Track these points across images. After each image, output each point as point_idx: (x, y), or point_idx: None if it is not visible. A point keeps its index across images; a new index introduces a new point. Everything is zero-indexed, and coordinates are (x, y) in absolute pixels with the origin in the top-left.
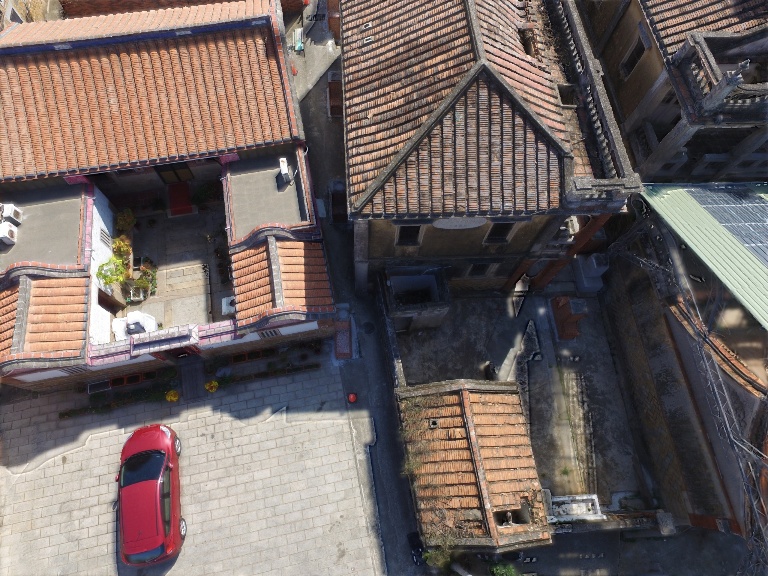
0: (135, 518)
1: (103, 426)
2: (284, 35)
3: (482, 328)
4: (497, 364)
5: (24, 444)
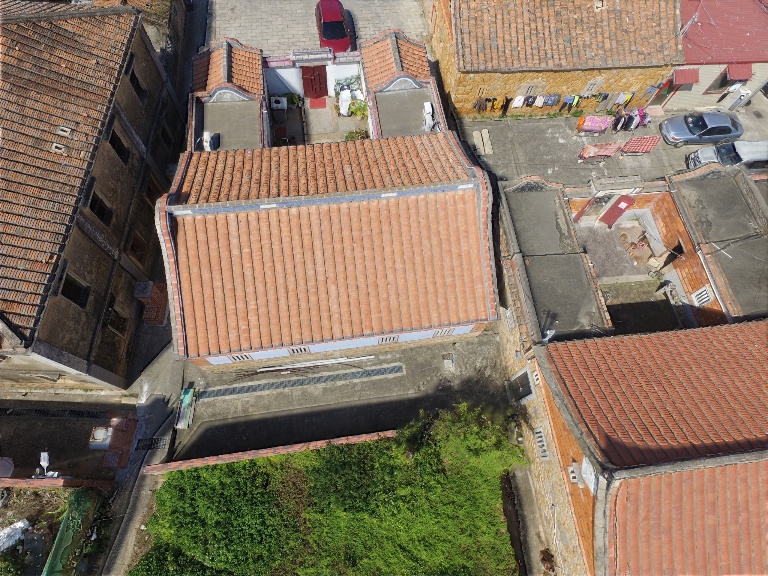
0: (333, 9)
1: None
2: None
3: None
4: None
5: None
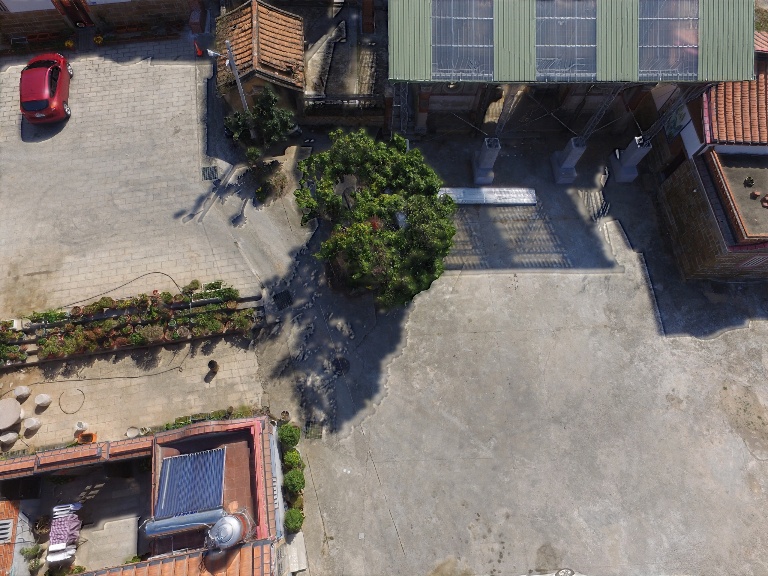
0: (30, 83)
1: (20, 62)
2: None
3: (305, 23)
4: (312, 42)
5: None
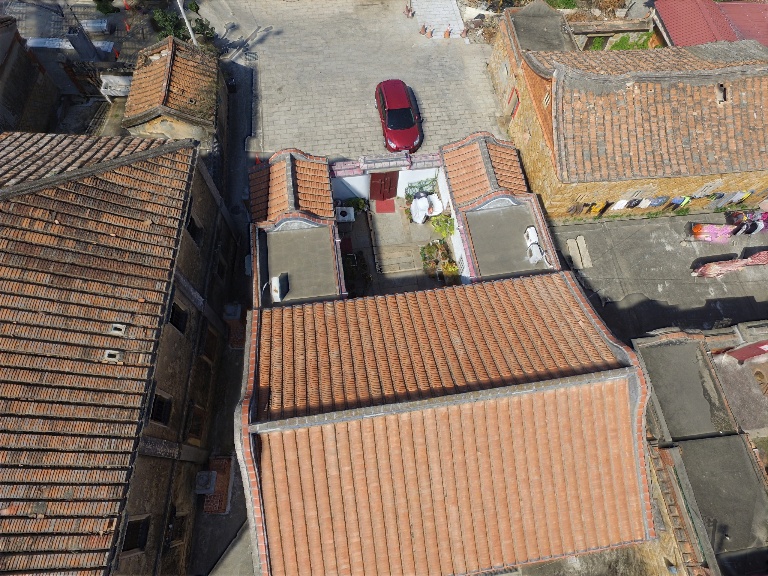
0: (398, 93)
1: None
2: (238, 405)
3: None
4: None
5: None
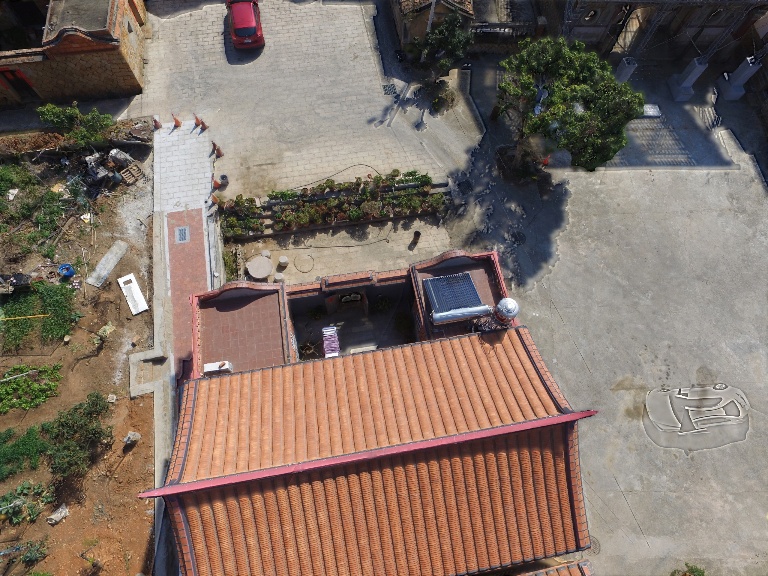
0: (240, 14)
1: (212, 2)
2: None
3: None
4: None
5: (166, 7)
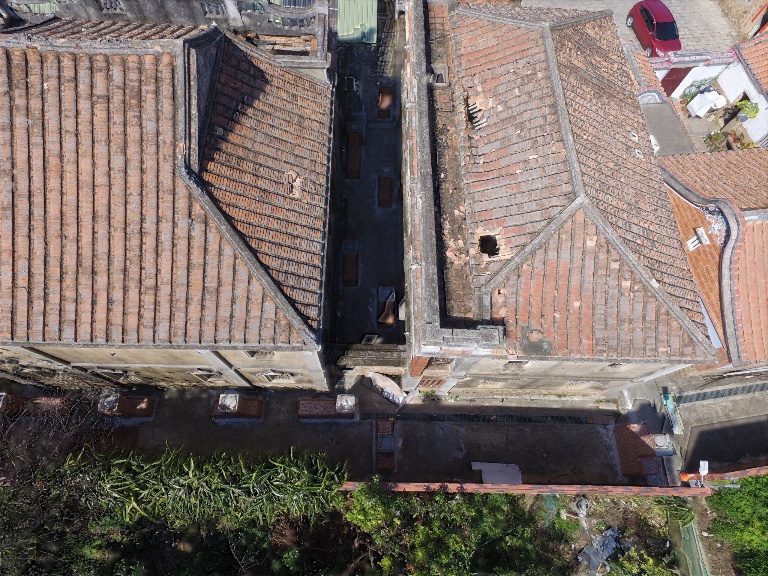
0: (661, 9)
1: None
2: None
3: None
4: None
5: None
